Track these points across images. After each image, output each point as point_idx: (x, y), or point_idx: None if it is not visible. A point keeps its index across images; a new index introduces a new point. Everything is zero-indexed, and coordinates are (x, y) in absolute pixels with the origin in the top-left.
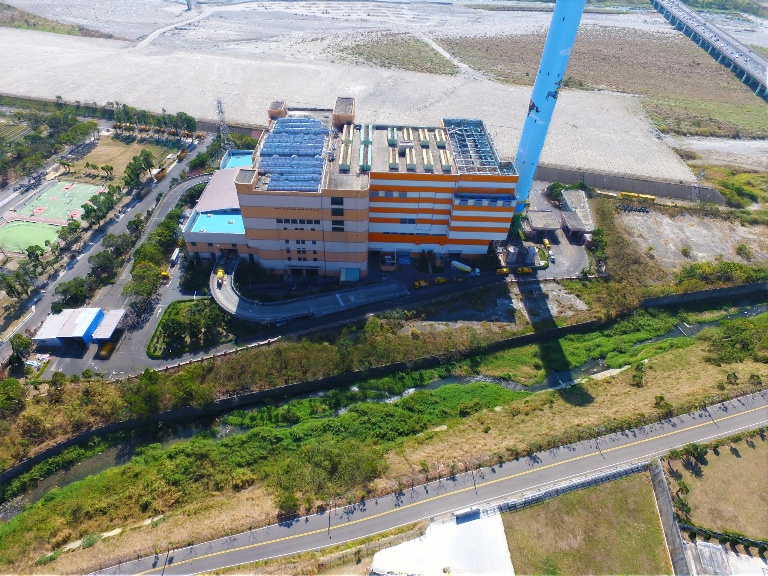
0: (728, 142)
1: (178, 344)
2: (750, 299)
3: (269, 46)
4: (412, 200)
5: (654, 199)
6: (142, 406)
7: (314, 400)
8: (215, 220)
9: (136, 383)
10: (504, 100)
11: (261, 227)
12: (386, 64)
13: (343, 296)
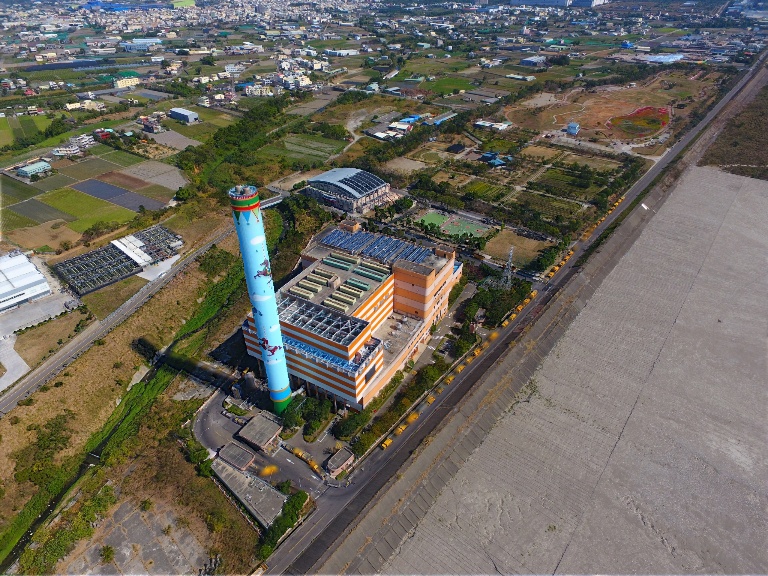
0: None
1: None
2: None
3: None
4: None
5: None
6: (286, 233)
7: None
8: None
9: None
10: None
11: None
12: None
13: None
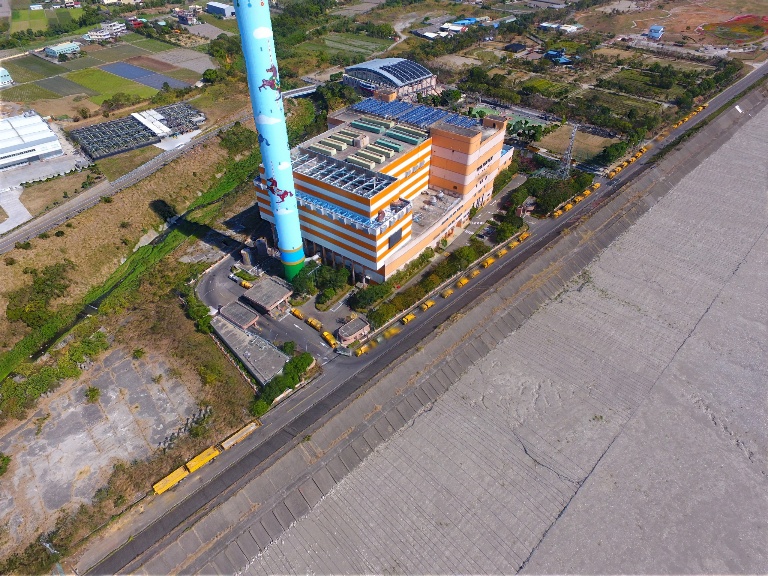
0: None
1: None
2: None
3: None
4: None
5: (157, 483)
6: None
7: None
8: None
9: None
10: None
11: None
12: None
13: None
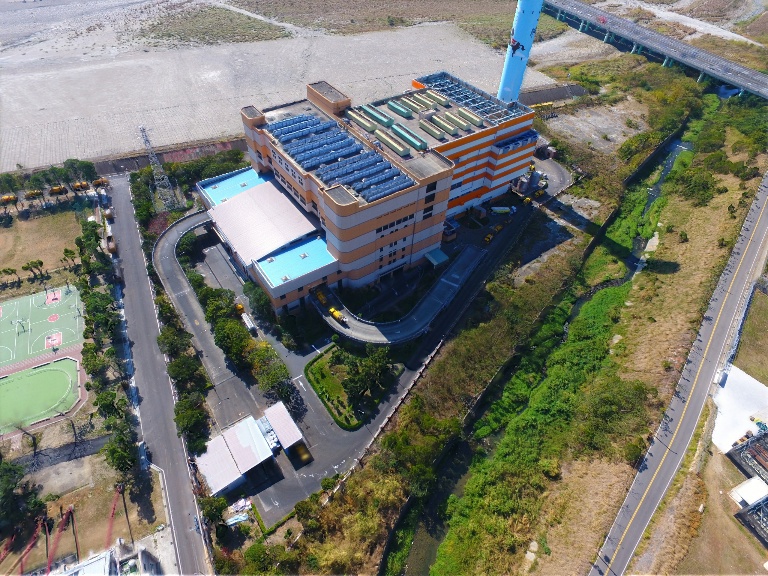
0: (539, 45)
1: (362, 402)
2: (660, 156)
3: (40, 49)
4: (461, 164)
5: (552, 104)
6: (428, 470)
7: (519, 375)
8: (283, 262)
9: (390, 457)
10: (362, 51)
11: (361, 245)
12: (210, 40)
13: (448, 278)
